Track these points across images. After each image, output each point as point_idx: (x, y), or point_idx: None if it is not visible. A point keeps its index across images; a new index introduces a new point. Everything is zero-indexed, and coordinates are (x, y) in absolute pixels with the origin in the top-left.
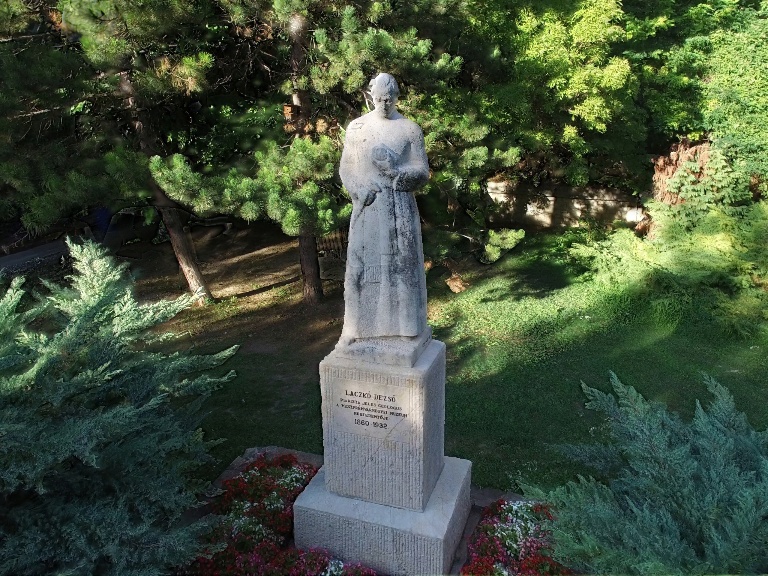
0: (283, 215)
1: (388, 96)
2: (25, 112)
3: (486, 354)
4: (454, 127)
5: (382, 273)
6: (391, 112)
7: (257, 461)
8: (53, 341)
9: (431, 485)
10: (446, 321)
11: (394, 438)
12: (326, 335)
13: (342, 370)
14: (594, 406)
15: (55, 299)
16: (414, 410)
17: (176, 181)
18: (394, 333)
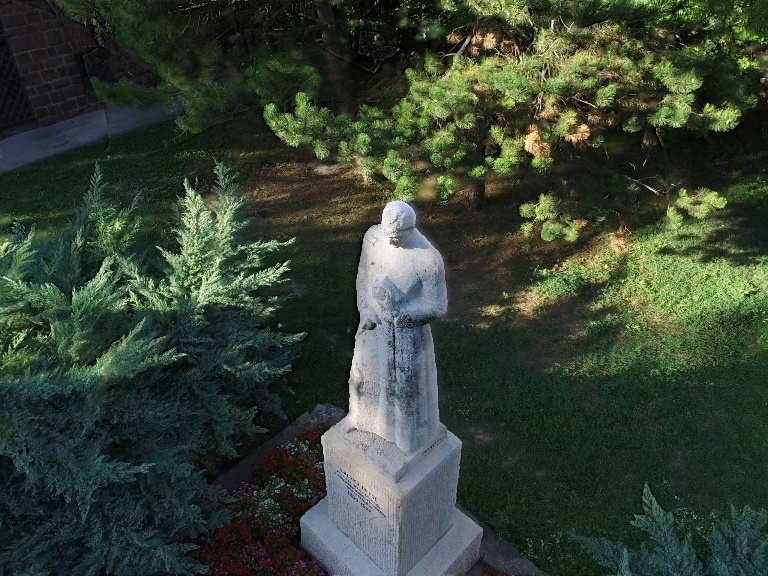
0: (398, 178)
1: (394, 235)
2: (184, 6)
3: (618, 340)
4: (658, 66)
5: (381, 390)
6: (403, 243)
7: (312, 432)
8: (106, 353)
9: (419, 555)
10: (600, 273)
11: (377, 524)
12: (464, 259)
13: (338, 452)
14: (641, 524)
15: (163, 250)
16: (392, 517)
17: (290, 131)
18: (391, 440)
